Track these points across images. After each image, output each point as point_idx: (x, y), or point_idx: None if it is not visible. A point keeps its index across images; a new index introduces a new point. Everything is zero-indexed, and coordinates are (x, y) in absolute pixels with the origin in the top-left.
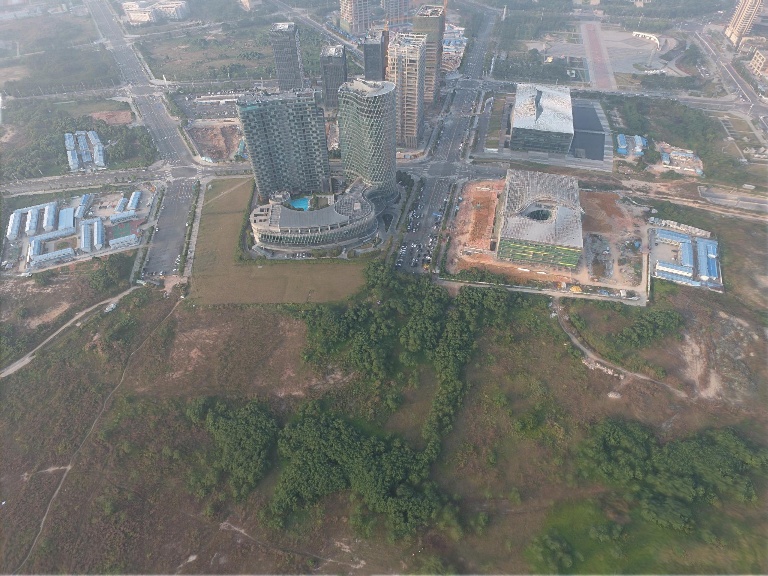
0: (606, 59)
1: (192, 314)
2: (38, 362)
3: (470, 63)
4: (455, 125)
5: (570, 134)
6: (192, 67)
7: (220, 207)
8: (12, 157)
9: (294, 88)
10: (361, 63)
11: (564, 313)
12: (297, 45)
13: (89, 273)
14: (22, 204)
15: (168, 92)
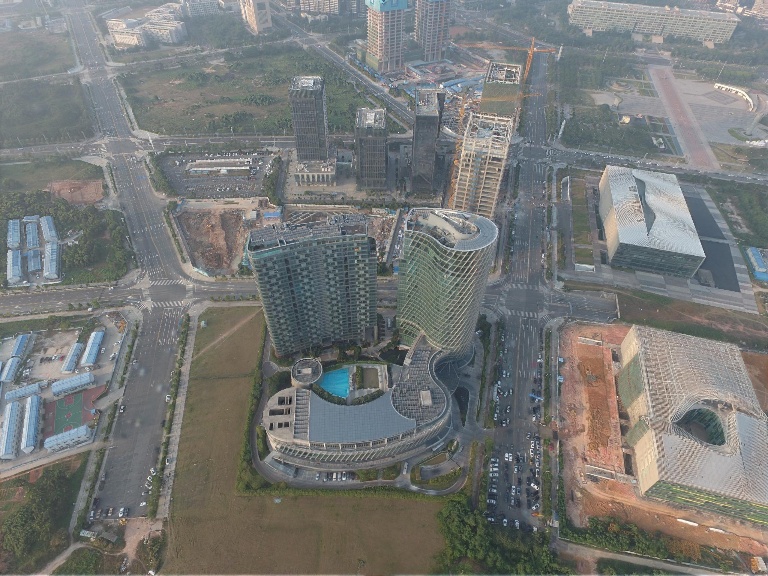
0: (693, 121)
1: None
2: None
3: (529, 120)
4: (528, 220)
5: (700, 257)
6: (186, 114)
7: (217, 364)
8: None
9: (317, 158)
10: (396, 116)
11: None
12: (324, 106)
13: (6, 509)
14: None
15: (154, 153)
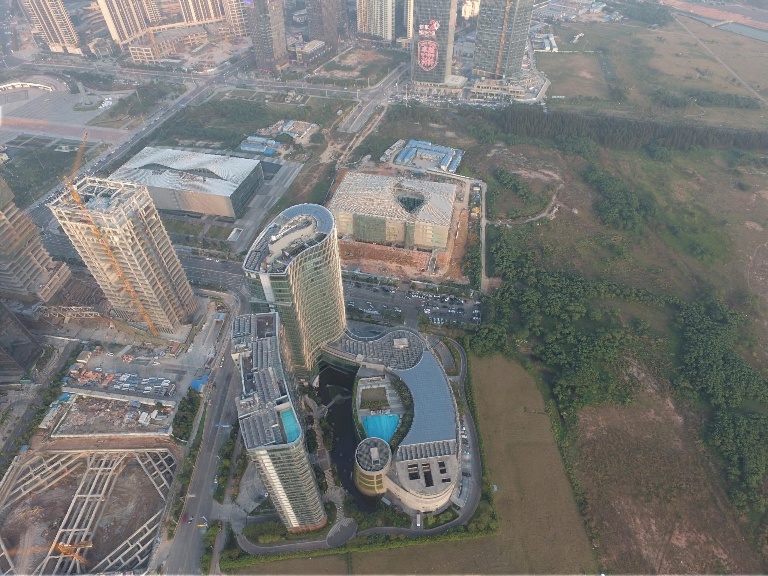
0: (42, 122)
1: (619, 572)
2: None
3: None
4: None
5: (258, 163)
6: None
7: None
8: None
9: None
10: None
11: (505, 220)
12: None
13: None
14: None
15: None
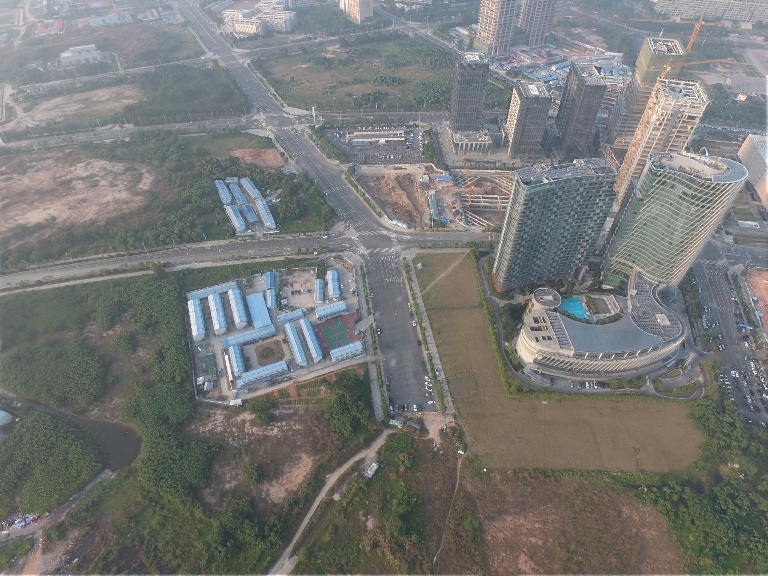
0: None
1: (489, 486)
2: (307, 572)
3: None
4: None
5: None
6: (326, 93)
7: (446, 298)
8: (160, 212)
9: (471, 129)
10: None
11: None
12: None
13: (319, 403)
14: (192, 283)
15: (314, 126)
